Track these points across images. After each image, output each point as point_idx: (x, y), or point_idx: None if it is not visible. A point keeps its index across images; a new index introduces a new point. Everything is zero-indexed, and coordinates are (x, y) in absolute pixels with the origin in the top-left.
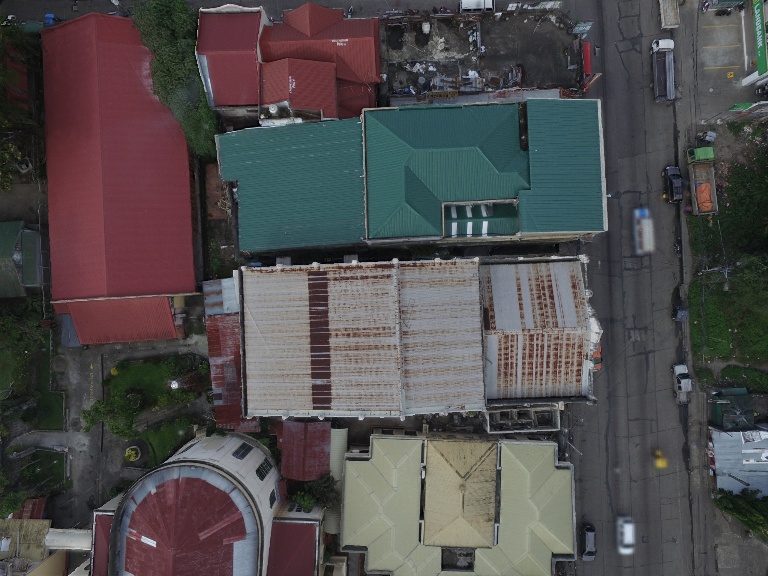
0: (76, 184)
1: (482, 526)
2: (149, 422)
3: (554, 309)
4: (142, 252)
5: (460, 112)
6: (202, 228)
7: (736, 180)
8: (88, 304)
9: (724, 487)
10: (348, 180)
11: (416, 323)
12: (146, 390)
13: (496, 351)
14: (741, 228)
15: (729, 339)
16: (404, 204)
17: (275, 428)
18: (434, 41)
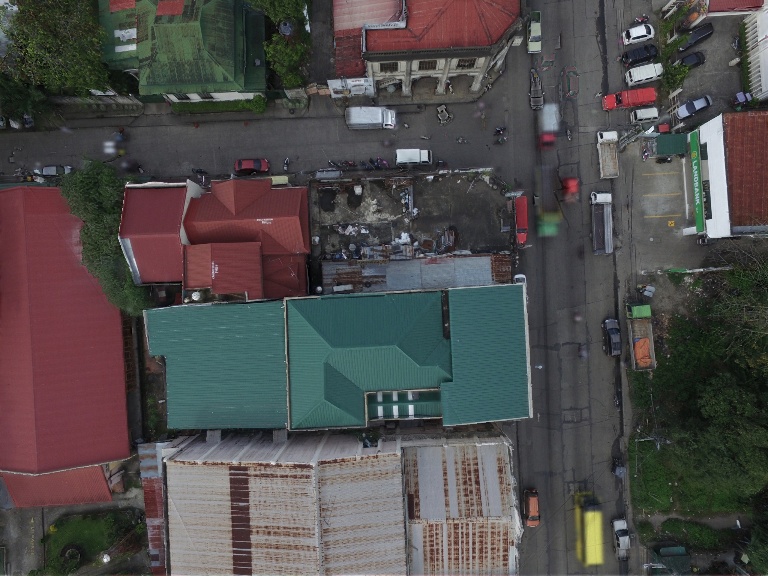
0: (8, 354)
1: None
2: (90, 575)
3: (479, 496)
4: (74, 422)
5: (382, 301)
6: (140, 382)
7: (676, 333)
8: None
9: None
10: (273, 364)
11: (337, 520)
12: (86, 544)
13: (421, 538)
14: (681, 380)
15: (669, 493)
16: (324, 401)
17: None
18: (366, 202)
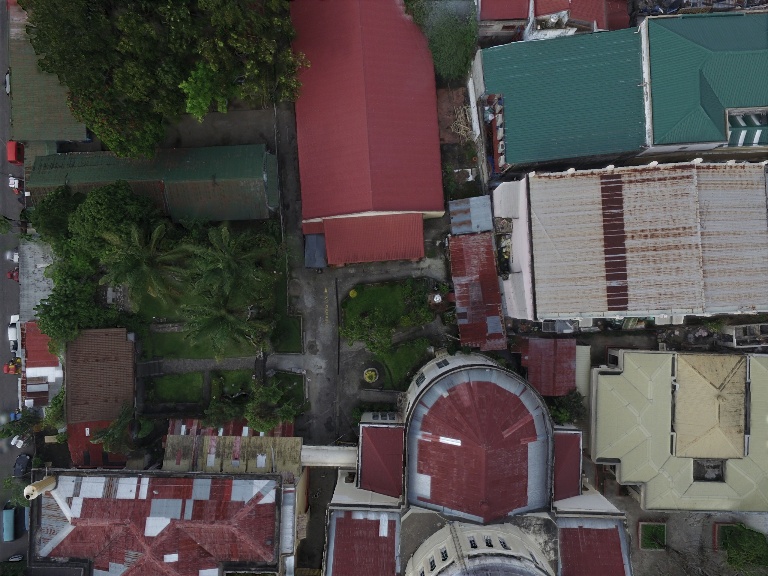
0: (333, 102)
1: (734, 437)
2: None
3: None
4: (399, 169)
5: (743, 19)
6: None
7: None
8: (343, 222)
9: None
10: (624, 90)
11: (711, 224)
12: None
13: None
14: None
15: None
16: (699, 107)
17: (519, 346)
18: None
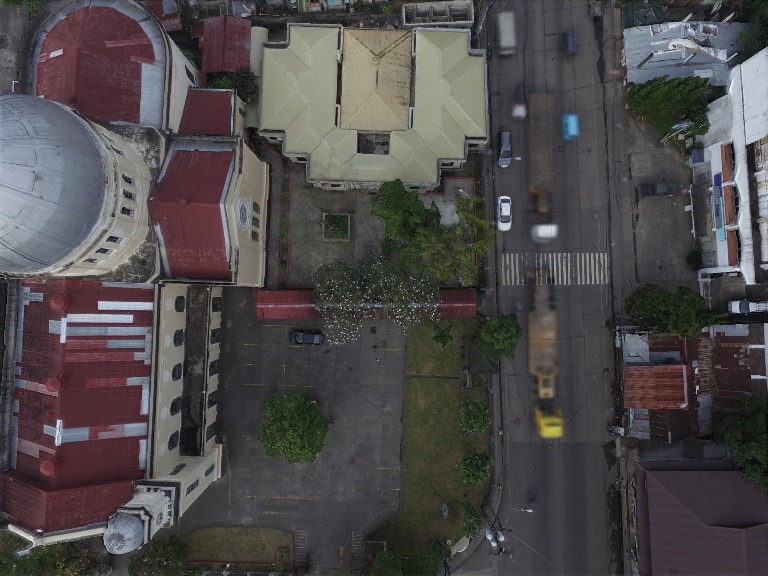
0: None
1: (396, 107)
2: None
3: None
4: None
5: None
6: None
7: None
8: None
9: (634, 81)
10: None
11: None
12: None
13: None
14: None
15: None
16: None
17: (197, 30)
18: None
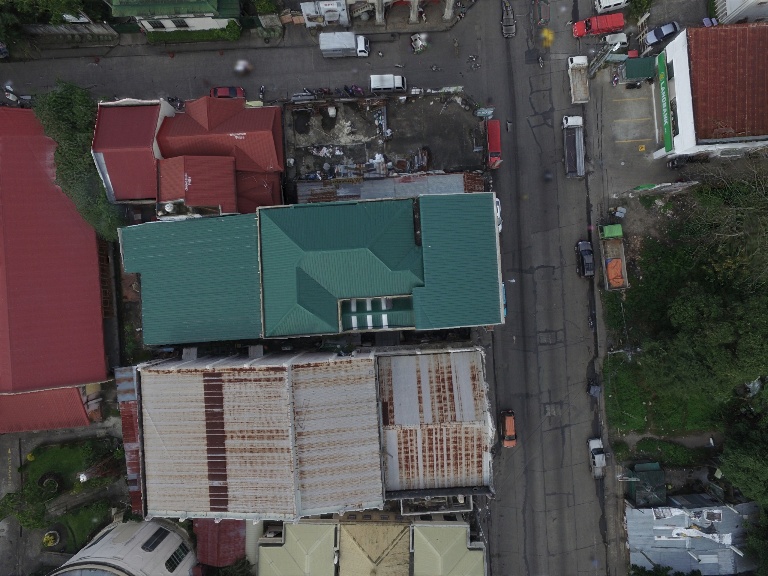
0: None
1: None
2: (68, 506)
3: (453, 402)
4: (49, 344)
5: (354, 209)
6: (118, 310)
7: (648, 254)
8: None
9: (637, 563)
10: (247, 276)
11: (311, 424)
12: (64, 474)
13: (396, 445)
14: (654, 301)
15: (643, 412)
16: (296, 305)
17: None
18: (341, 125)
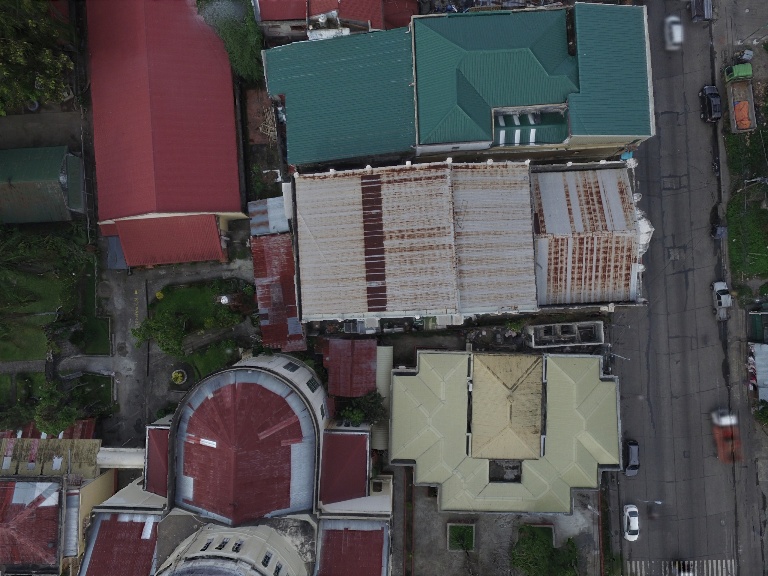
0: (122, 104)
1: (529, 437)
2: (194, 346)
3: (603, 213)
4: (189, 170)
5: (509, 18)
6: (244, 153)
7: None
8: (136, 223)
9: (765, 398)
10: (397, 90)
11: (469, 224)
12: (191, 314)
13: (546, 255)
14: None
15: (767, 256)
16: (456, 107)
17: (321, 347)
18: None
